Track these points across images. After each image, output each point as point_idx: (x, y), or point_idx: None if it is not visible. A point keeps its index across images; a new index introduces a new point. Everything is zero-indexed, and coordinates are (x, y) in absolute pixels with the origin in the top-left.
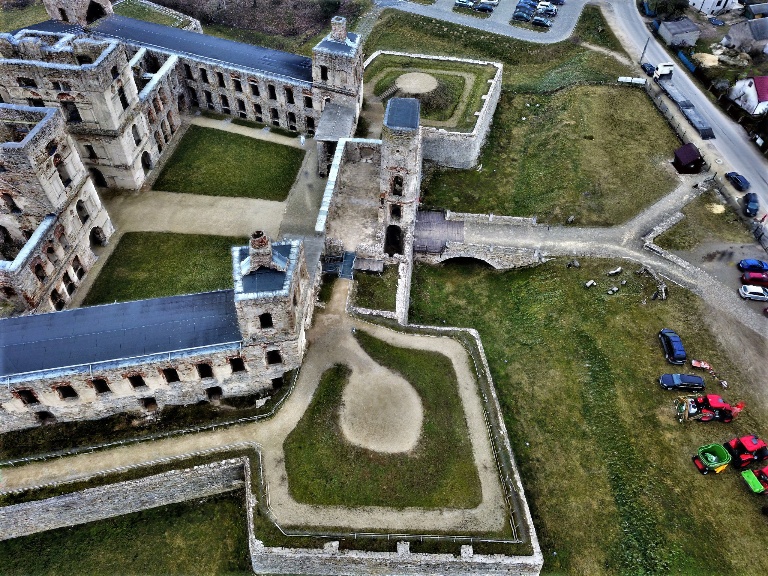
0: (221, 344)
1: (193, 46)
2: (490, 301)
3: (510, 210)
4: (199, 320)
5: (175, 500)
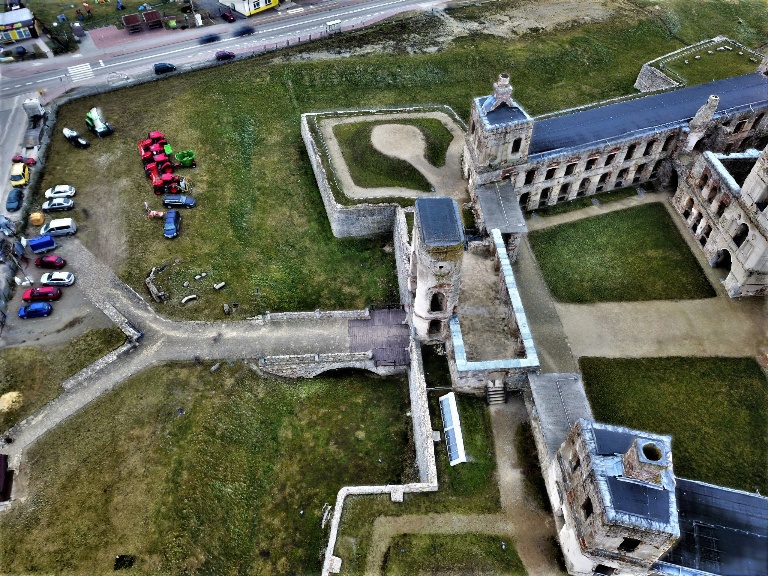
0: None
1: None
2: (319, 292)
3: (286, 423)
4: (538, 134)
5: None
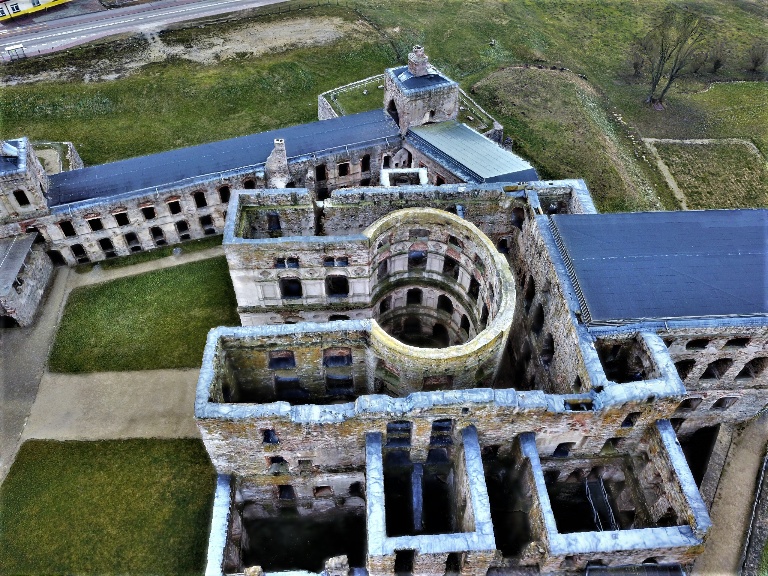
0: None
1: None
2: None
3: None
4: (81, 181)
5: None
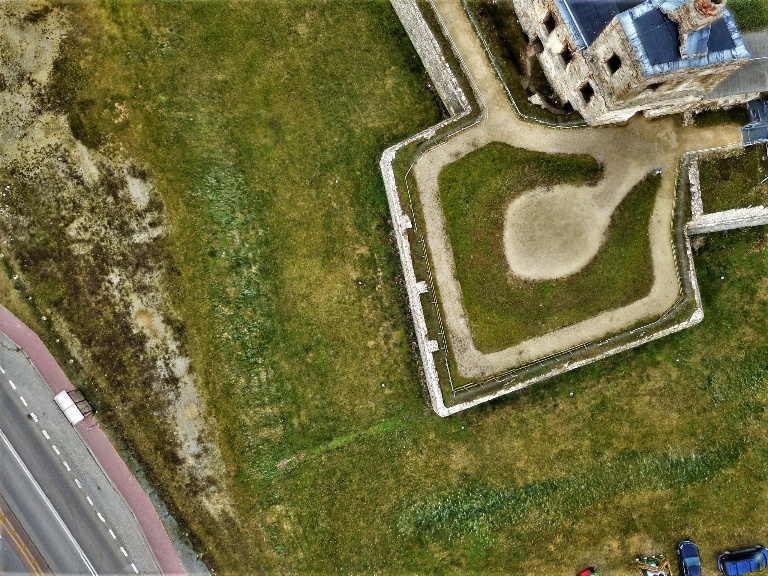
0: (577, 25)
1: None
2: None
3: None
4: None
5: (423, 60)
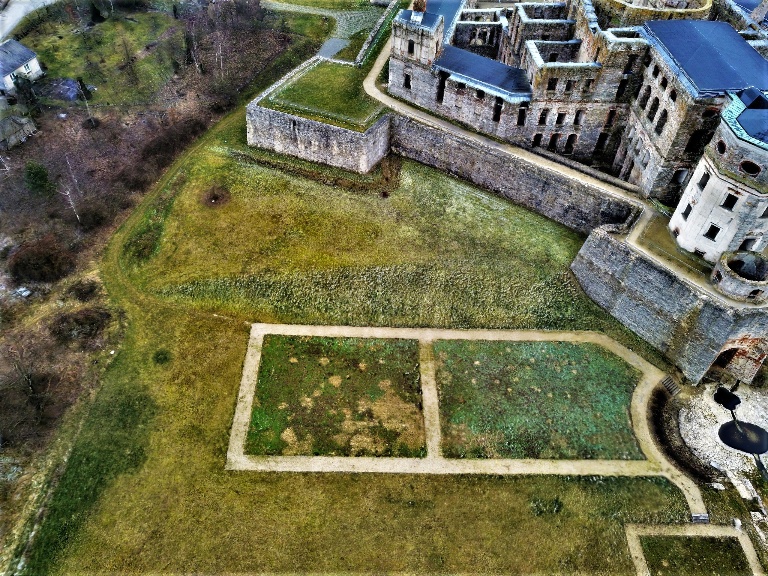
0: None
1: (451, 0)
2: None
3: None
4: None
5: None
